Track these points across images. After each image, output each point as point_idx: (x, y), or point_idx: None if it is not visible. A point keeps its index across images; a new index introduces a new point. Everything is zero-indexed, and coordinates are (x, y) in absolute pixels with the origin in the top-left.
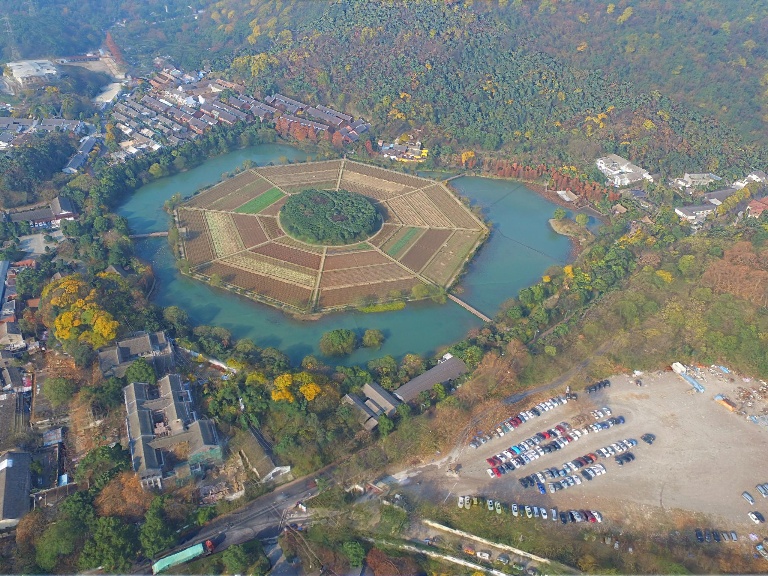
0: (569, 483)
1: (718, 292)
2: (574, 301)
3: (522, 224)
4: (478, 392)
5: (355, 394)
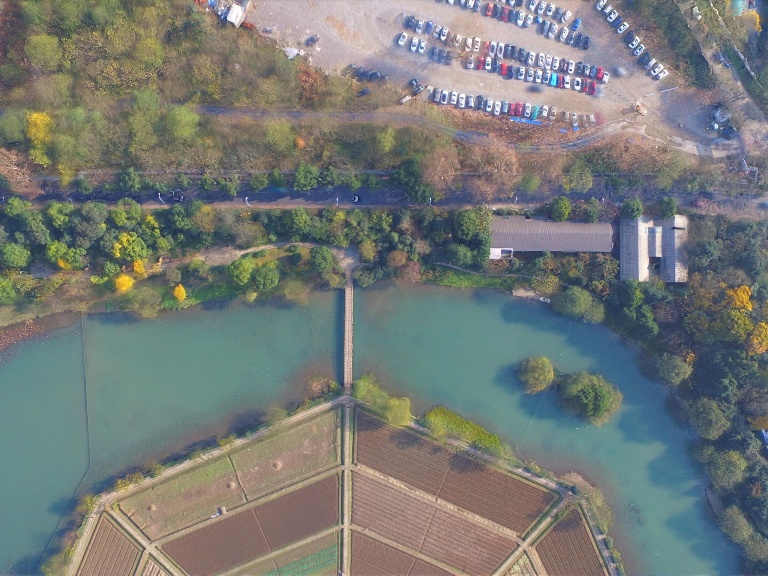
0: (547, 5)
1: (0, 45)
2: (215, 212)
3: (8, 479)
4: (507, 183)
5: (662, 279)
